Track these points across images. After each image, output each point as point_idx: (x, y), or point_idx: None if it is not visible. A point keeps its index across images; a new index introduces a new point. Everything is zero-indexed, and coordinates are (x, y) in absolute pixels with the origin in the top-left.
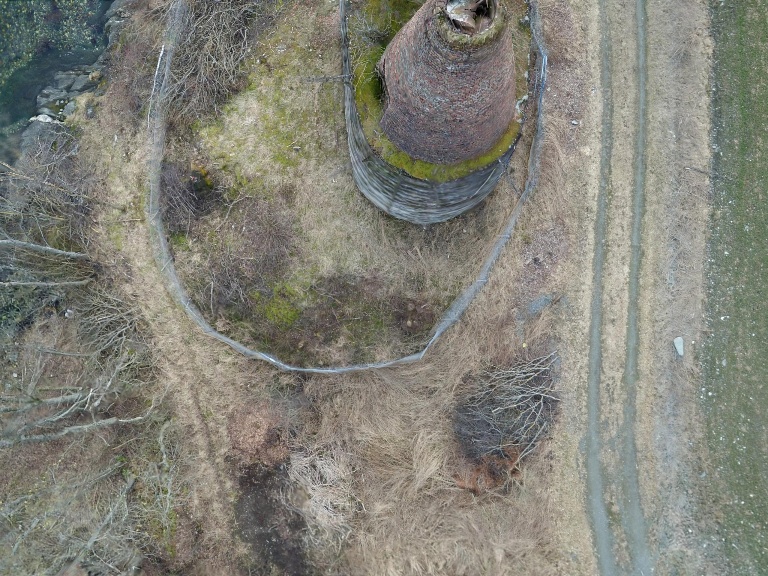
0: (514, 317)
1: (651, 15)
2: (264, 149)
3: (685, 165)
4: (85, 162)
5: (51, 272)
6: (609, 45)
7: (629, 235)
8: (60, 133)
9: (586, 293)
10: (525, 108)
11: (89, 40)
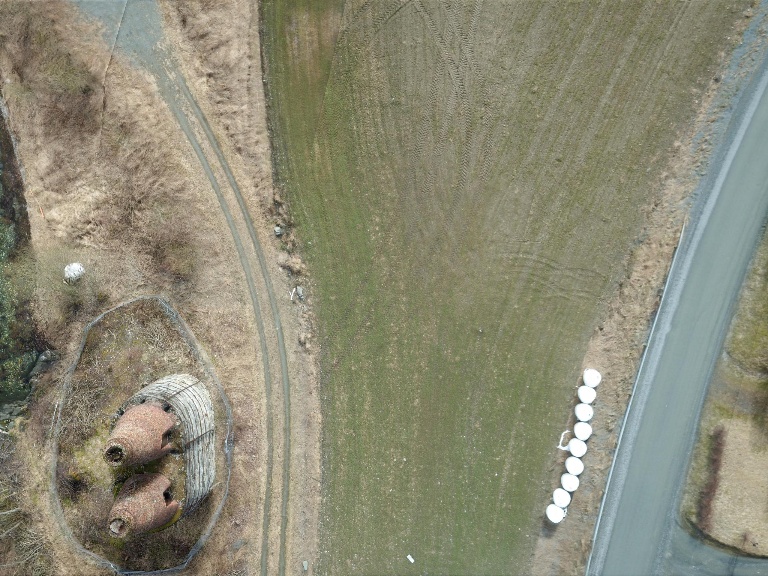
0: (227, 550)
1: (292, 402)
2: (104, 465)
3: (309, 476)
4: (19, 458)
5: (0, 520)
6: (272, 417)
7: (281, 511)
8: (6, 440)
9: (260, 540)
10: (184, 502)
11: (22, 386)
